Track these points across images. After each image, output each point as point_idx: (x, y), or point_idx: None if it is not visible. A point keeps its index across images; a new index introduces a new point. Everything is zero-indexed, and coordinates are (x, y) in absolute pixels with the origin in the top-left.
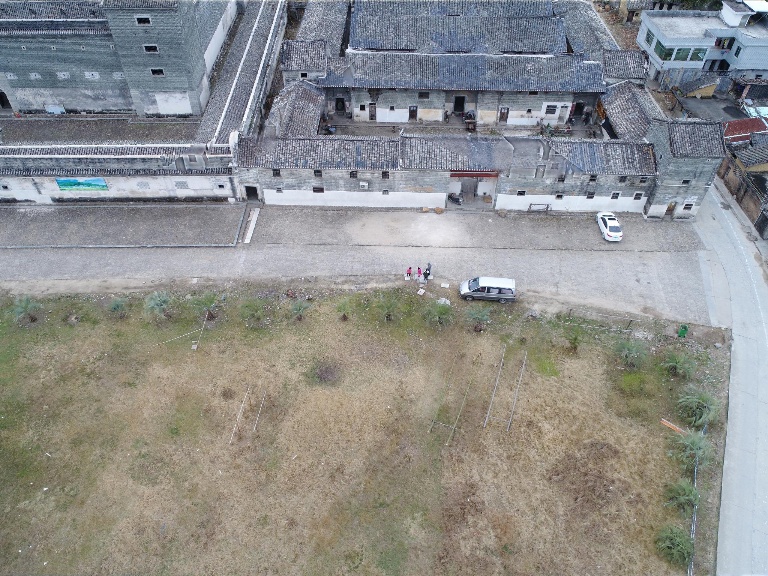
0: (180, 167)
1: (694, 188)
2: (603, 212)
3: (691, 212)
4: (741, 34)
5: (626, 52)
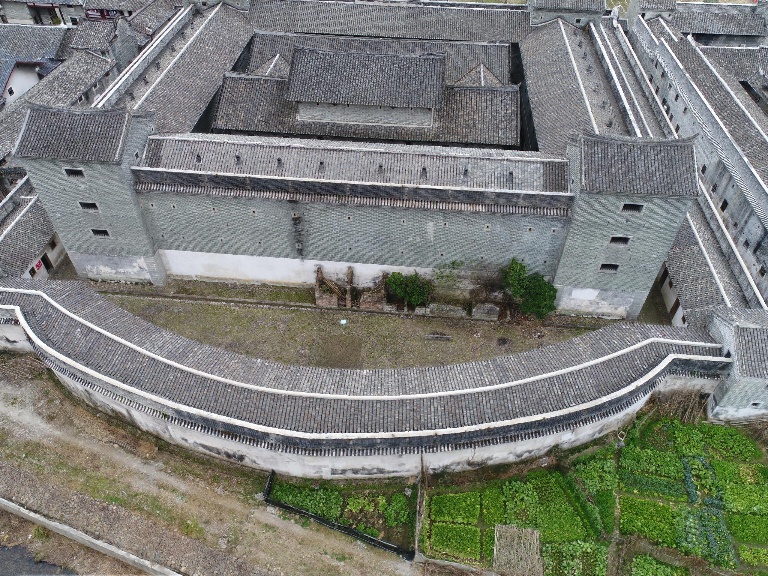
0: None
1: None
2: None
3: None
4: None
5: None
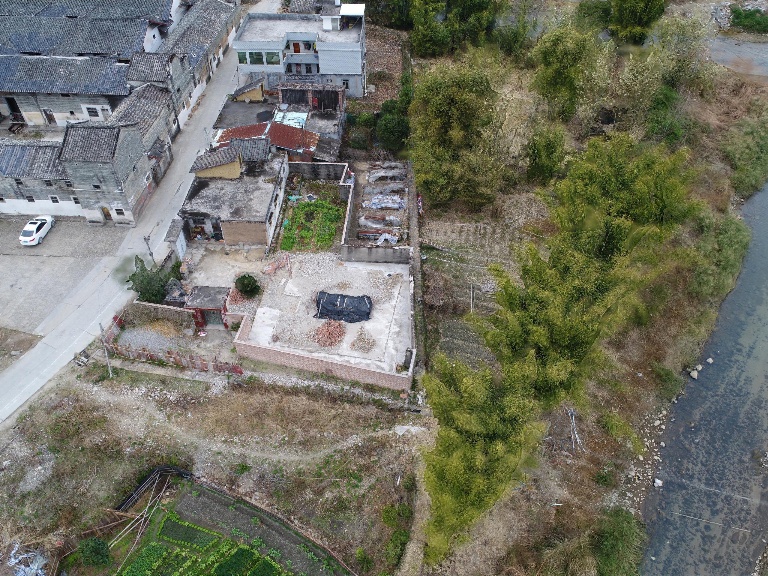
0: None
1: (110, 193)
2: (43, 216)
3: (127, 217)
4: (316, 38)
5: (157, 55)
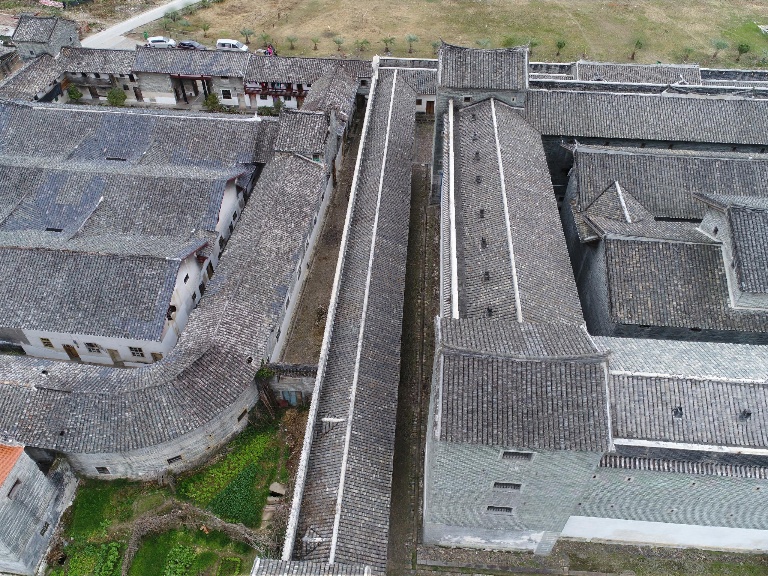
0: (430, 108)
1: None
2: None
3: None
4: None
5: None
